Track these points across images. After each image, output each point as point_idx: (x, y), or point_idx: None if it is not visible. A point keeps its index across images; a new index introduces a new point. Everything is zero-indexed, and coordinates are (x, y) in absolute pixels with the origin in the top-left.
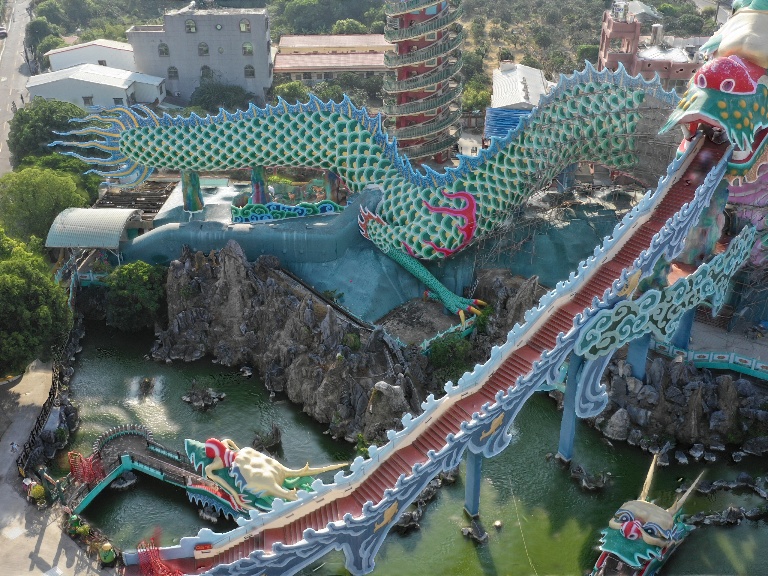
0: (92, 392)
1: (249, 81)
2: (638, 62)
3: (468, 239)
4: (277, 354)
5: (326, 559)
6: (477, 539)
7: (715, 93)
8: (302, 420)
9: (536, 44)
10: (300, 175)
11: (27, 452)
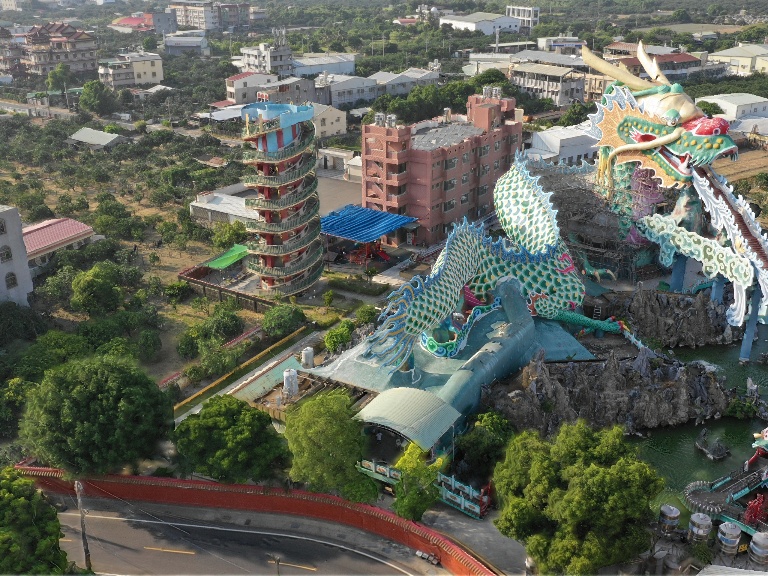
0: None
1: (11, 292)
2: (432, 153)
3: None
4: (618, 408)
5: None
6: None
7: (727, 136)
8: (672, 432)
9: (99, 182)
10: (265, 337)
11: (710, 546)
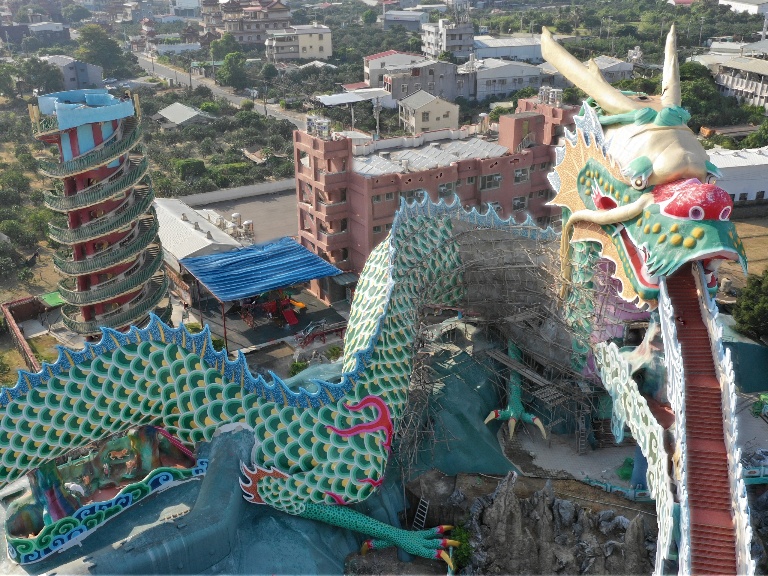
0: None
1: None
2: (369, 180)
3: (391, 453)
4: None
5: None
6: None
7: (719, 224)
8: None
9: None
10: None
11: None
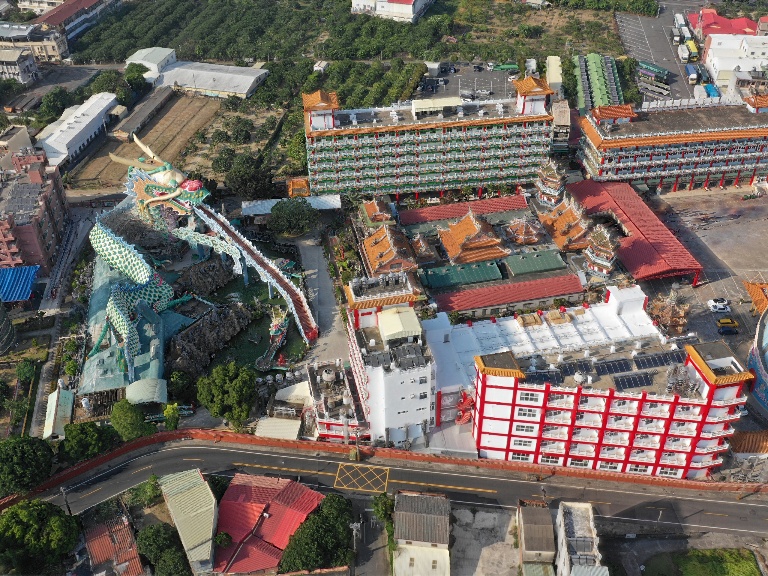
0: None
1: None
2: None
3: None
4: None
5: None
6: None
7: None
8: None
9: None
10: (21, 383)
11: None
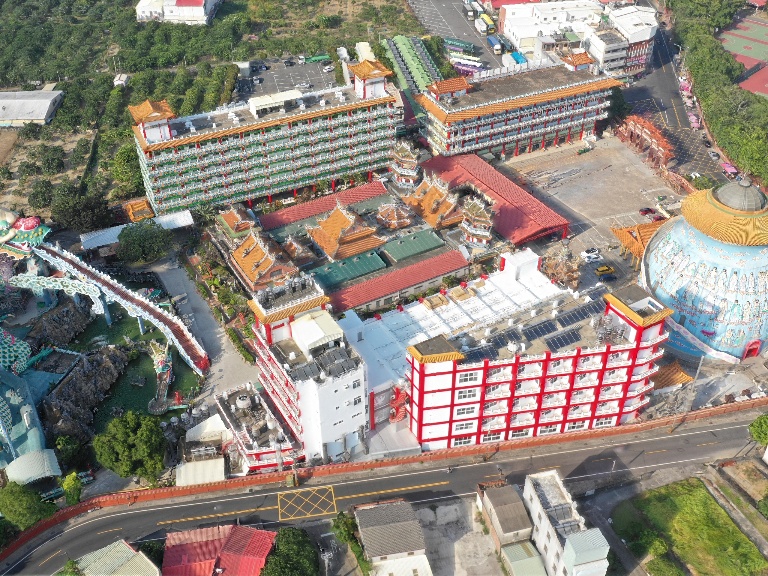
0: None
1: None
2: None
3: None
4: None
5: (176, 350)
6: (154, 329)
7: (42, 225)
8: None
9: None
10: None
11: None
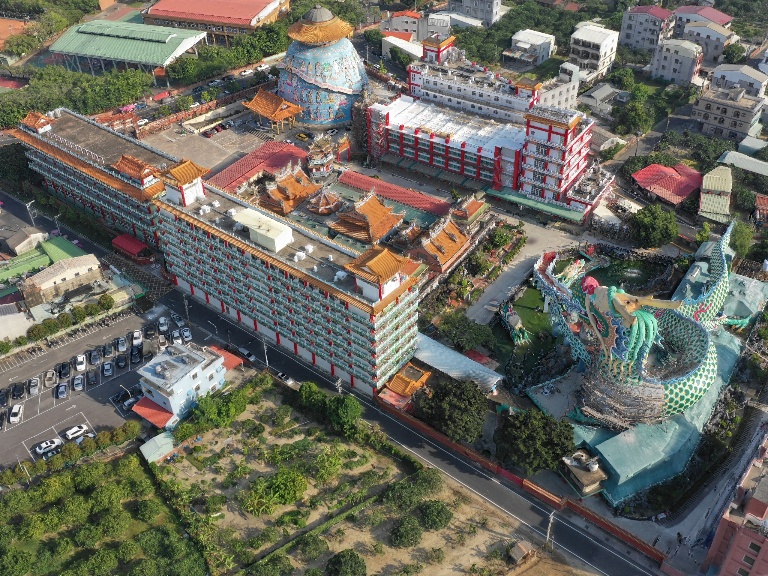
0: (640, 265)
1: None
2: None
3: None
4: None
5: None
6: None
7: None
8: None
9: None
10: None
11: None
